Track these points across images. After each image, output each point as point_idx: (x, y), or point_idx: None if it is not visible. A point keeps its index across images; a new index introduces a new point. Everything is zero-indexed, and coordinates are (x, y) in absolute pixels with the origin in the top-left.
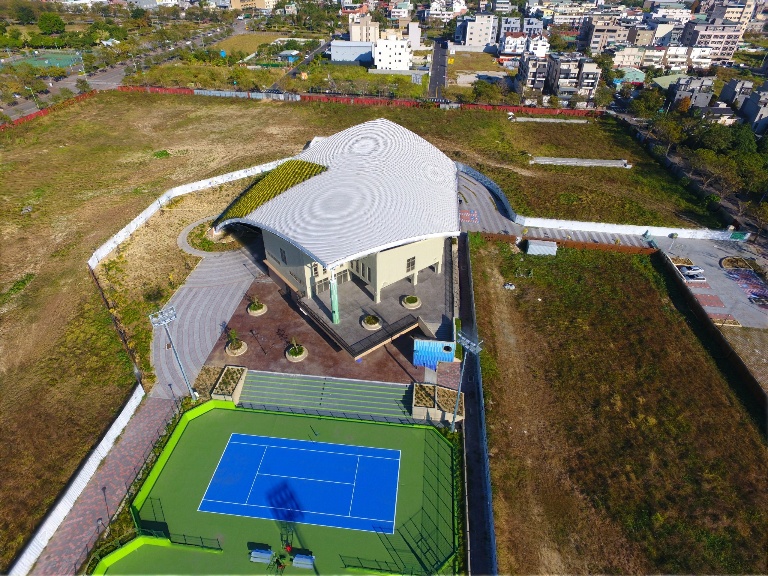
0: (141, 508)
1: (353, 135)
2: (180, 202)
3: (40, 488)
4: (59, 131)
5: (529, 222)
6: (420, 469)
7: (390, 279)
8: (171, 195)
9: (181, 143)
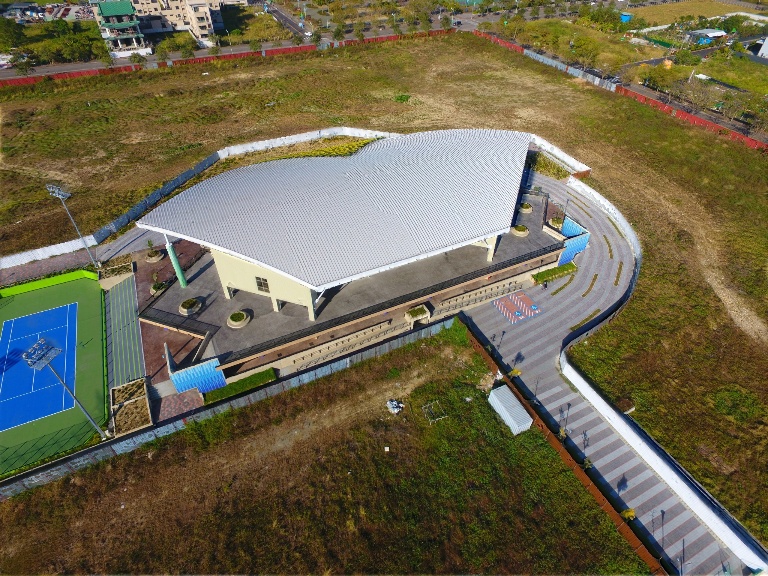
0: (5, 297)
1: (453, 137)
2: (336, 141)
3: (8, 251)
4: (381, 56)
5: (569, 373)
6: (52, 429)
7: (237, 283)
8: (340, 132)
9: (432, 95)
